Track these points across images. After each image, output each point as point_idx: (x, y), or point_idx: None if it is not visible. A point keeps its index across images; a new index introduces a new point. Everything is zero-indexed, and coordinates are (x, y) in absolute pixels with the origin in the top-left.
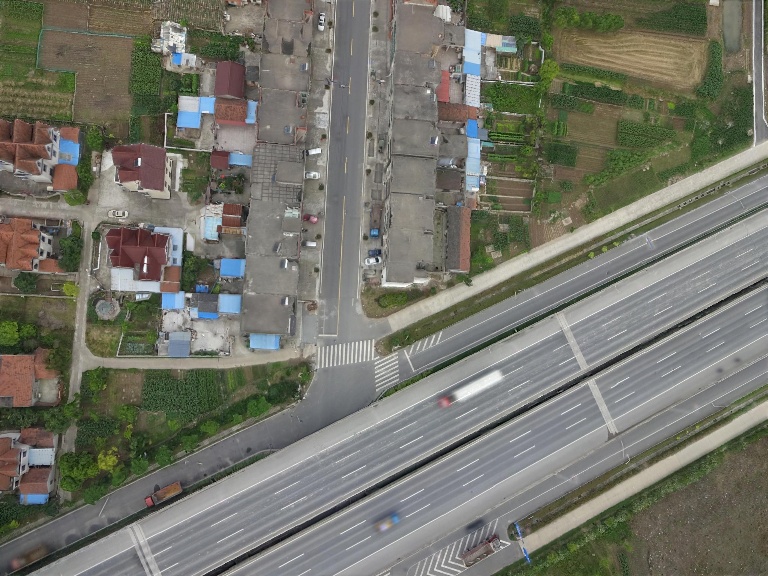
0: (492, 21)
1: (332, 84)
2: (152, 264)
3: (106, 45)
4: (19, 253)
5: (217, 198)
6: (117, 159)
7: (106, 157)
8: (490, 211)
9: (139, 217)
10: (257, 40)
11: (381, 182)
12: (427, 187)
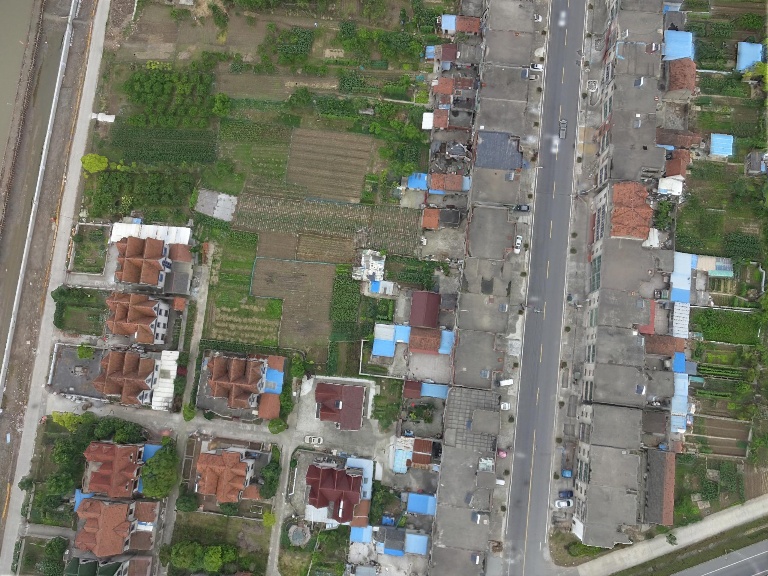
0: (703, 238)
1: (526, 309)
2: (346, 507)
3: (311, 272)
4: (228, 487)
5: (406, 426)
6: (319, 398)
7: (305, 382)
8: (697, 453)
9: (332, 443)
10: (452, 265)
11: (575, 416)
12: (631, 440)
